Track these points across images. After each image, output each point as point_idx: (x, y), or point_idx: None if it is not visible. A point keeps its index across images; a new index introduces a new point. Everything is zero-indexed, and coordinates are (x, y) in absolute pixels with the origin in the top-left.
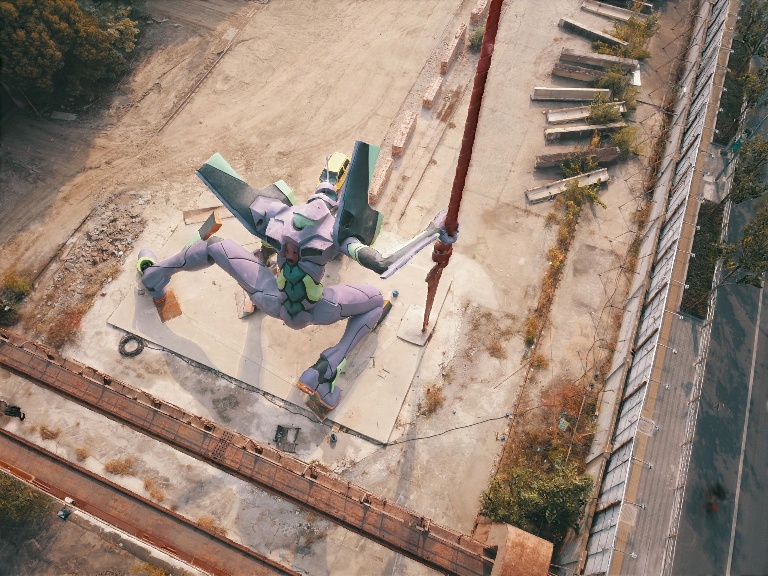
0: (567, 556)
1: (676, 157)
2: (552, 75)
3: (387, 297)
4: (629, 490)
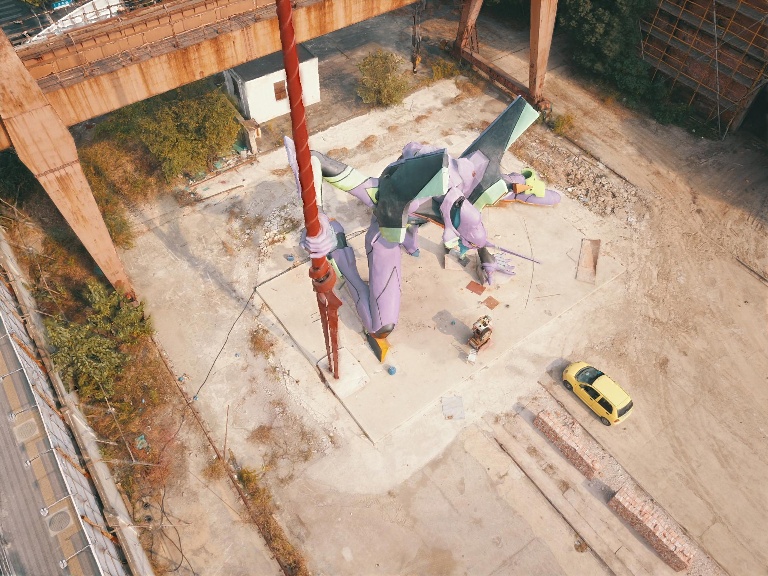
0: None
1: None
2: None
3: (394, 363)
4: (36, 449)
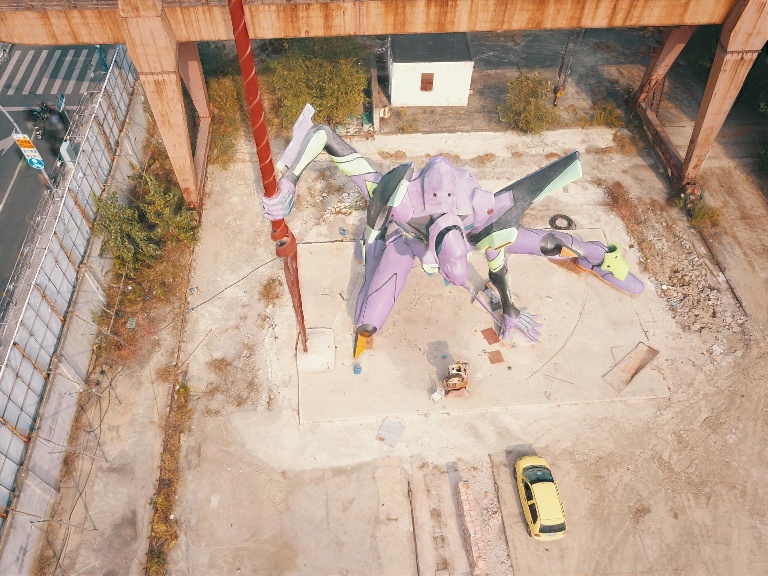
0: None
1: None
2: None
3: (365, 364)
4: None
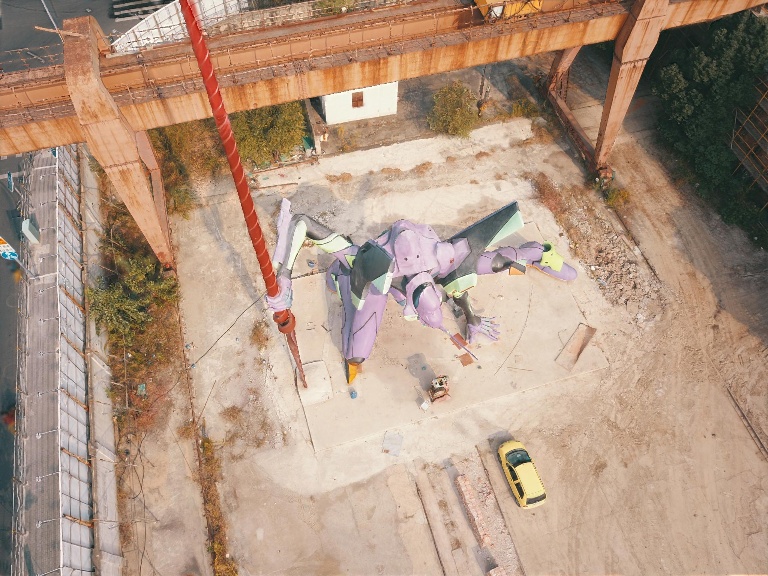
0: None
1: None
2: None
3: (359, 388)
4: None
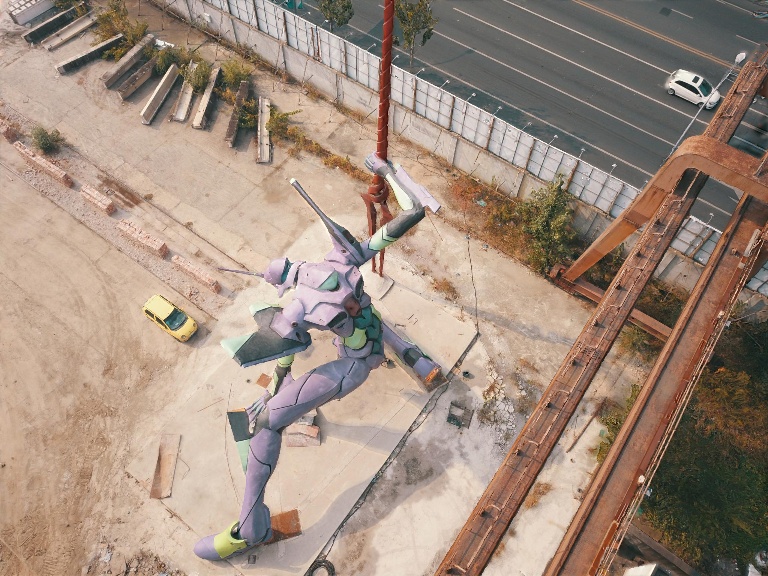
0: (584, 226)
1: (282, 43)
2: (125, 101)
3: None
4: None
